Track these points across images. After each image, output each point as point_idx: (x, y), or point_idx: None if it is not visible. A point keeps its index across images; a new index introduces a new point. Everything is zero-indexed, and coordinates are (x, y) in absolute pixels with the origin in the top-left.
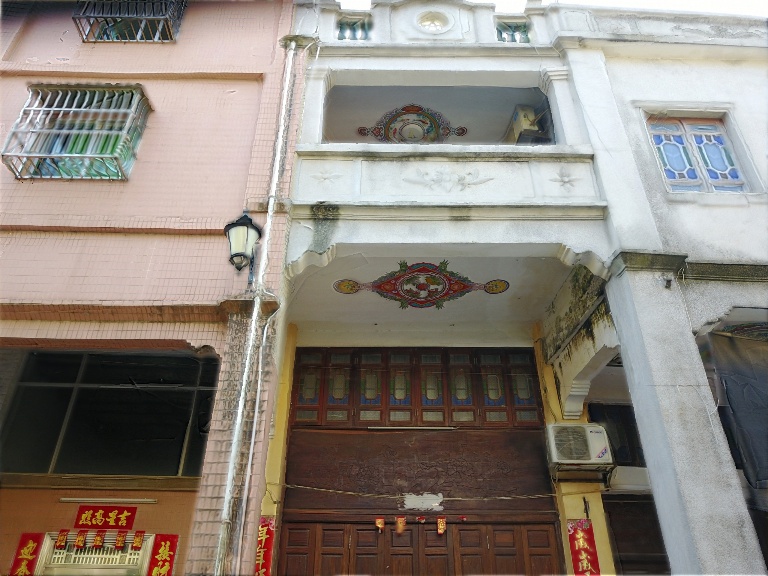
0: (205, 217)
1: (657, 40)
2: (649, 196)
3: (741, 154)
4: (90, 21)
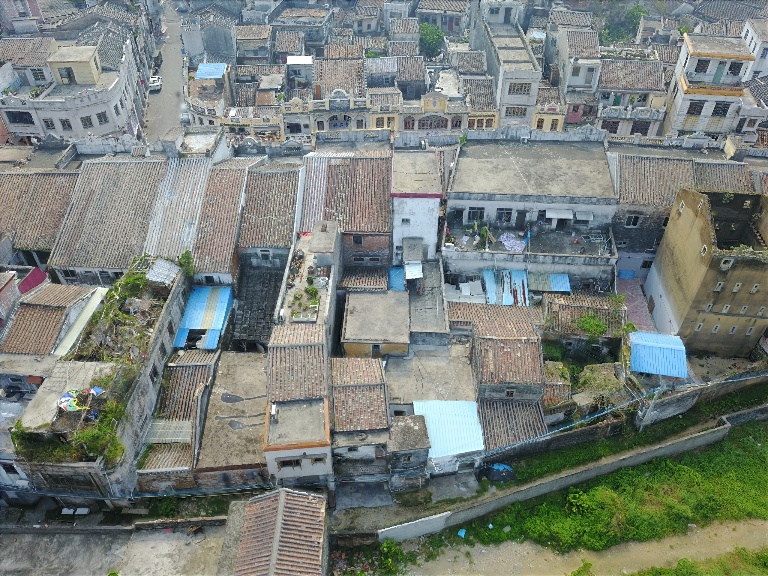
0: (3, 133)
1: (41, 109)
2: (45, 131)
3: (54, 125)
4: None
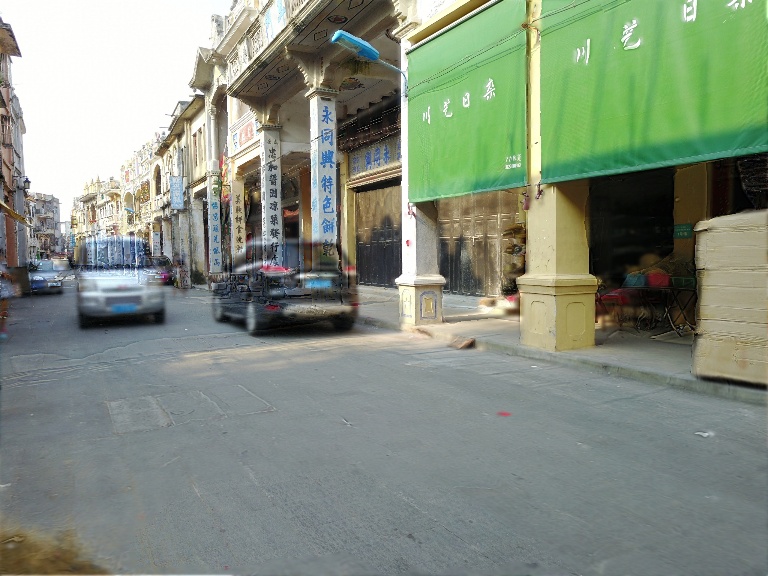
0: None
1: None
2: None
3: None
4: (7, 82)
